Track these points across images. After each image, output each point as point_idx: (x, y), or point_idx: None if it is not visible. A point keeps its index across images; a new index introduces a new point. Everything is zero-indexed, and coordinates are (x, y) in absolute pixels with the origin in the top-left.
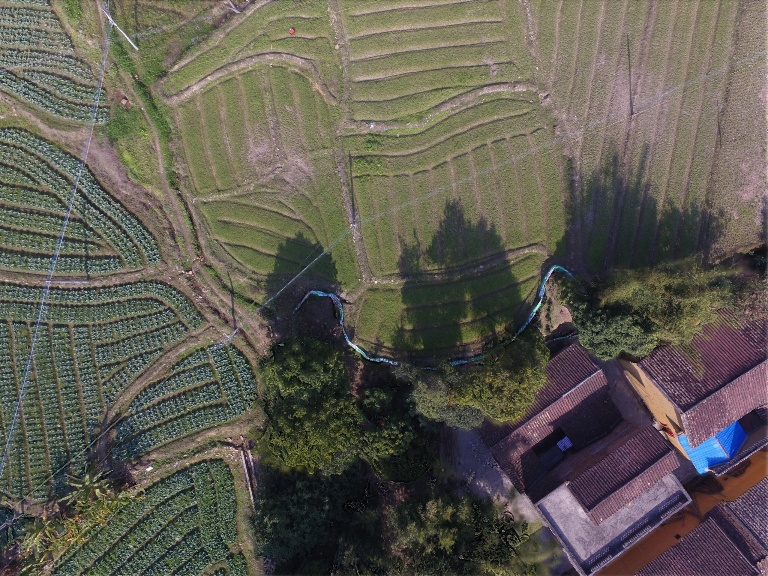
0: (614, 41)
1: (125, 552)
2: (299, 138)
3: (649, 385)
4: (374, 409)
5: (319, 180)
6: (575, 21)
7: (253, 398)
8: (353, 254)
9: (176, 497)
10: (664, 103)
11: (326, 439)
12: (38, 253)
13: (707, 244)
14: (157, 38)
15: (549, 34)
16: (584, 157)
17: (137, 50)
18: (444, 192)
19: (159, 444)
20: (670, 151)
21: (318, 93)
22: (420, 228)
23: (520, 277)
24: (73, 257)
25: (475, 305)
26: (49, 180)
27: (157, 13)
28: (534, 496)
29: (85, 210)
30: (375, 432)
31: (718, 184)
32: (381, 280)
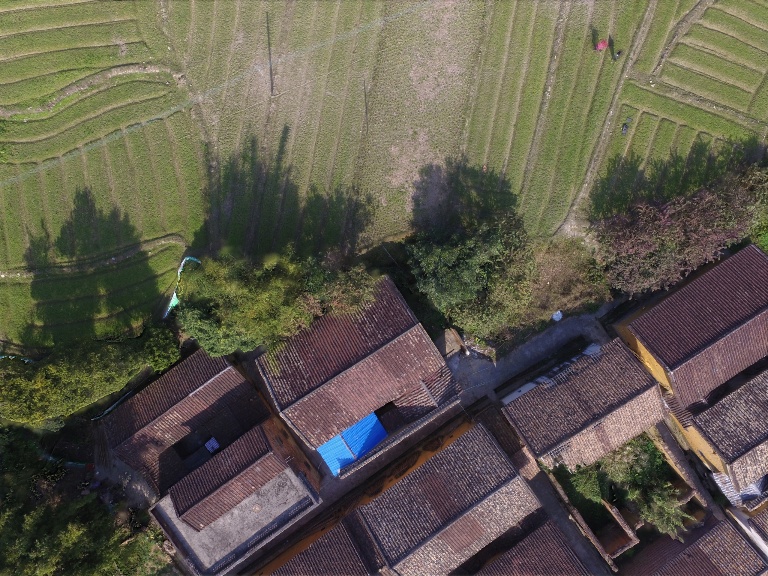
0: (252, 18)
1: None
2: None
3: None
4: None
5: None
6: None
7: None
8: None
9: None
10: (307, 83)
11: None
12: None
13: (353, 233)
14: None
15: (182, 11)
16: (220, 142)
17: None
18: (74, 180)
19: None
20: (314, 134)
21: None
22: (49, 218)
23: (158, 269)
24: None
25: (109, 299)
26: None
27: None
28: None
29: None
30: None
31: (365, 169)
32: (7, 274)
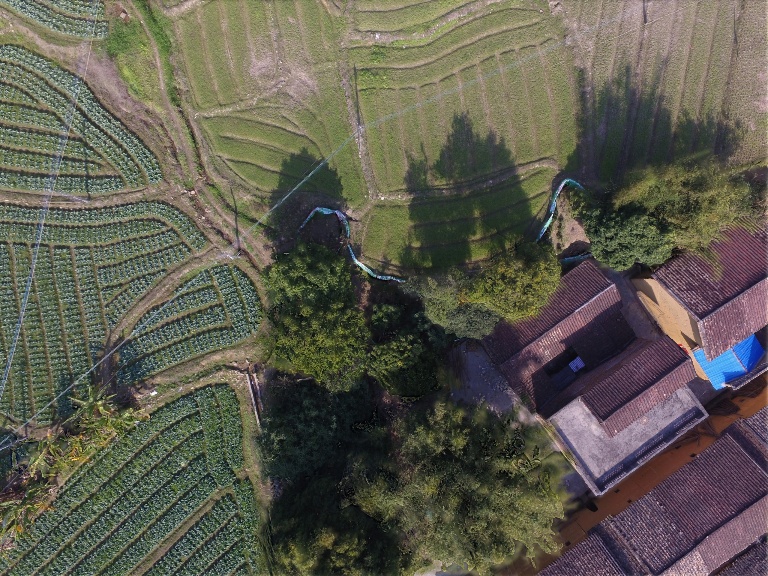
0: None
1: (130, 477)
2: (302, 51)
3: (664, 301)
4: (382, 325)
5: (323, 94)
6: None
7: (258, 320)
8: (359, 170)
9: (181, 422)
10: (678, 11)
11: (334, 341)
12: (38, 173)
13: (723, 156)
14: None
15: None
16: (596, 67)
17: None
18: (452, 105)
19: (163, 367)
20: (685, 61)
21: (321, 4)
22: (427, 142)
23: (530, 192)
24: (73, 177)
25: (484, 221)
26: (48, 98)
27: None
28: (546, 413)
29: (85, 128)
30: (383, 345)
31: (735, 94)
32: (388, 196)
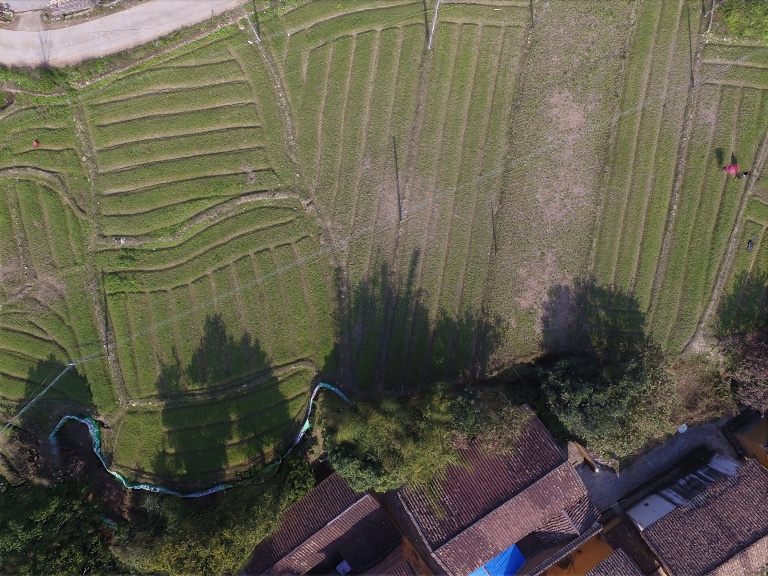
0: (380, 143)
1: None
2: (49, 255)
3: None
4: None
5: (71, 299)
6: (338, 123)
7: None
8: (110, 375)
9: None
10: (434, 207)
11: None
12: None
13: (484, 355)
14: None
15: (310, 138)
16: (350, 267)
17: None
18: (204, 308)
19: None
20: (442, 257)
21: (68, 207)
22: (179, 346)
23: (288, 394)
24: None
25: (240, 426)
26: None
27: None
28: None
29: None
30: None
31: (494, 291)
32: (139, 403)
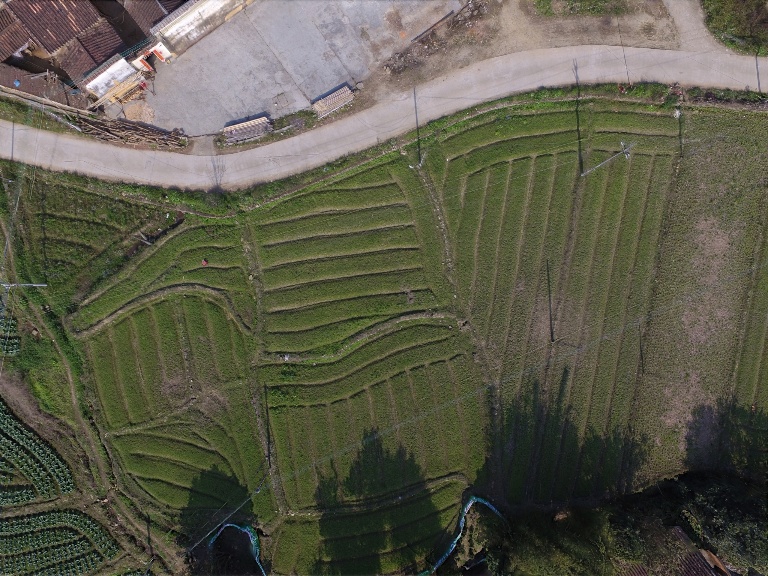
0: (533, 266)
1: None
2: (213, 368)
3: None
4: None
5: (234, 411)
6: (494, 246)
7: None
8: (269, 485)
9: None
10: (585, 328)
11: None
12: None
13: (630, 472)
14: (66, 273)
15: (467, 260)
16: (504, 385)
17: (46, 286)
18: (362, 422)
19: None
20: (592, 377)
21: (232, 322)
22: (337, 459)
23: (440, 506)
24: None
25: (394, 536)
26: None
27: (66, 248)
28: None
29: None
30: None
31: (641, 410)
32: (298, 513)
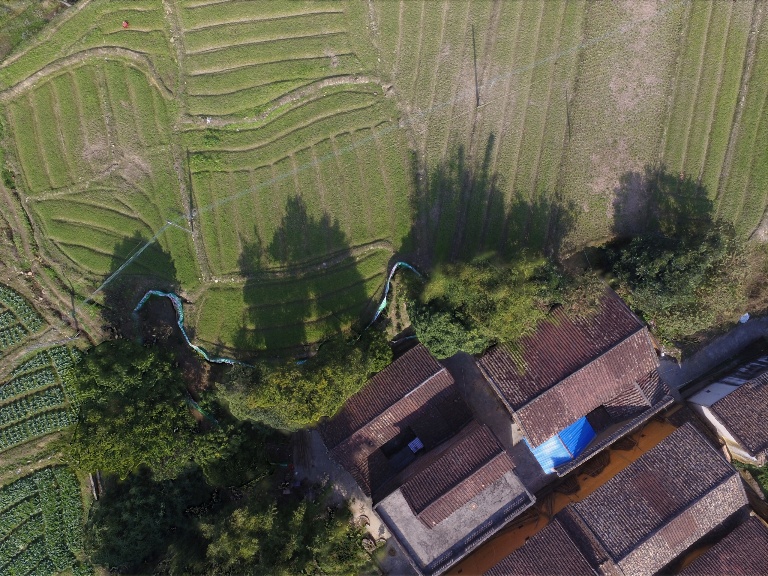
0: (459, 31)
1: None
2: (136, 134)
3: None
4: (209, 412)
5: (157, 177)
6: (418, 11)
7: None
8: (193, 252)
9: (19, 504)
10: (511, 94)
11: (129, 444)
12: None
13: (557, 238)
14: None
15: (391, 24)
16: (429, 150)
17: None
18: (285, 188)
19: None
20: (518, 143)
21: (155, 88)
22: (261, 225)
23: (366, 274)
24: None
25: (319, 303)
26: None
27: None
28: (375, 499)
29: None
30: (202, 435)
31: (568, 176)
32: (221, 279)
